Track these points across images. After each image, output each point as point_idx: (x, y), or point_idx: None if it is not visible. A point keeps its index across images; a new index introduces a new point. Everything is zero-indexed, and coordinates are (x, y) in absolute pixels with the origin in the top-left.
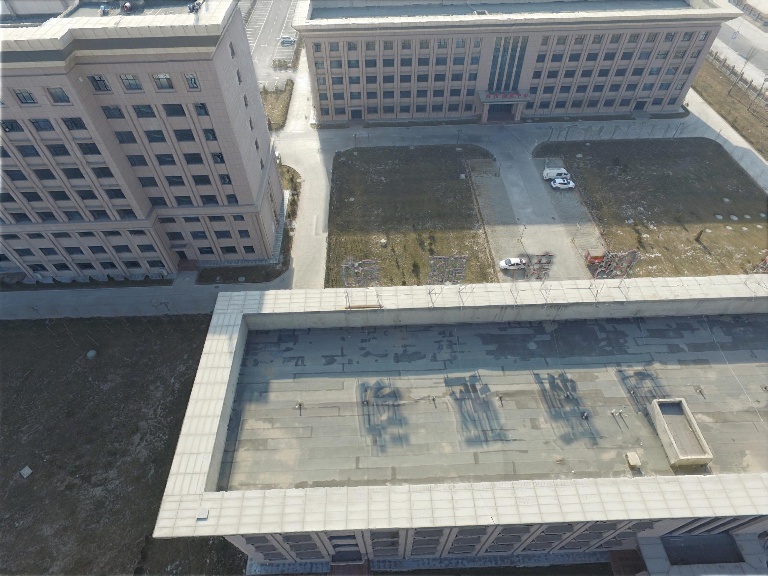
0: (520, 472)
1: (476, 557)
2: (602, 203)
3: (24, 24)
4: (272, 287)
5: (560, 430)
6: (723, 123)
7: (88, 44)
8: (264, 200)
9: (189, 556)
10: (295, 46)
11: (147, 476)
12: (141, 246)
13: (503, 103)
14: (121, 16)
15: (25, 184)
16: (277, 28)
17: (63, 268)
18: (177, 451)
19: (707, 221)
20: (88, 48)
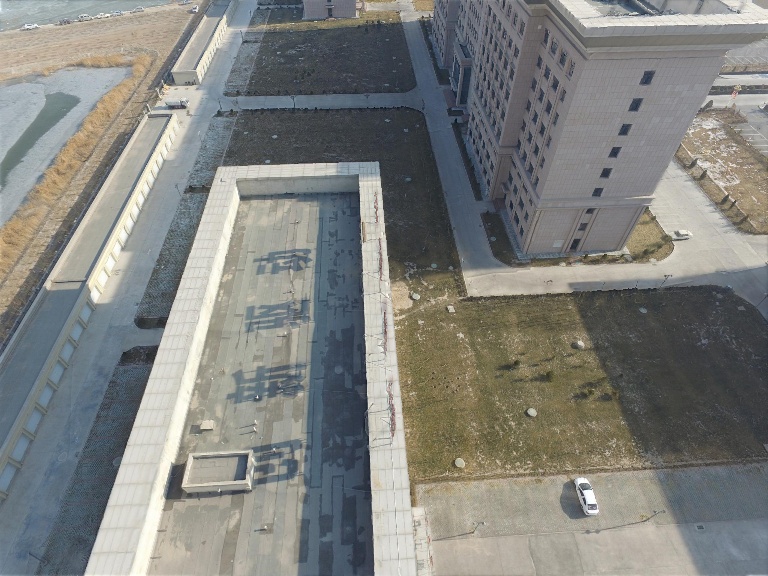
0: (222, 342)
1: None
2: None
3: None
4: (489, 260)
5: (249, 376)
6: None
7: None
8: (566, 214)
9: None
10: None
11: None
12: None
13: None
14: None
15: None
16: None
17: None
18: (262, 166)
19: None
20: (549, 6)
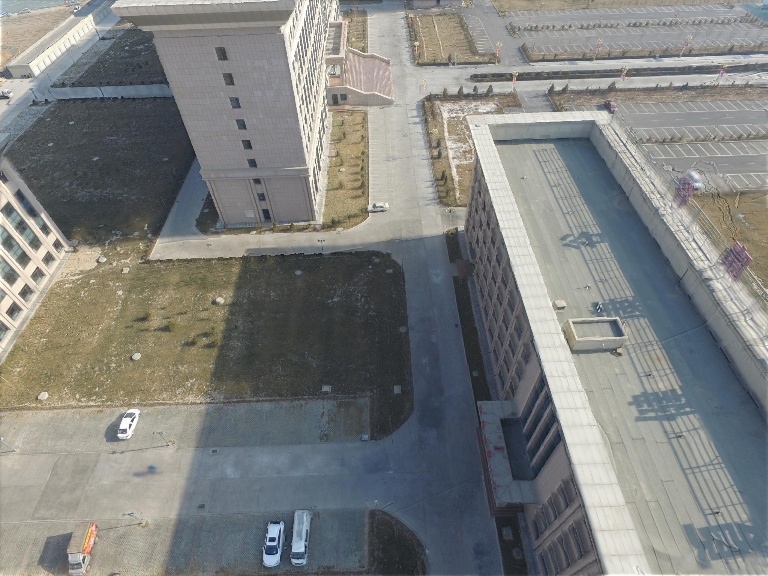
0: None
1: None
2: None
3: None
4: (189, 229)
5: None
6: None
7: None
8: (237, 185)
9: None
10: None
11: (63, 199)
12: None
13: None
14: None
15: None
16: (734, 168)
17: None
18: None
19: None
20: None
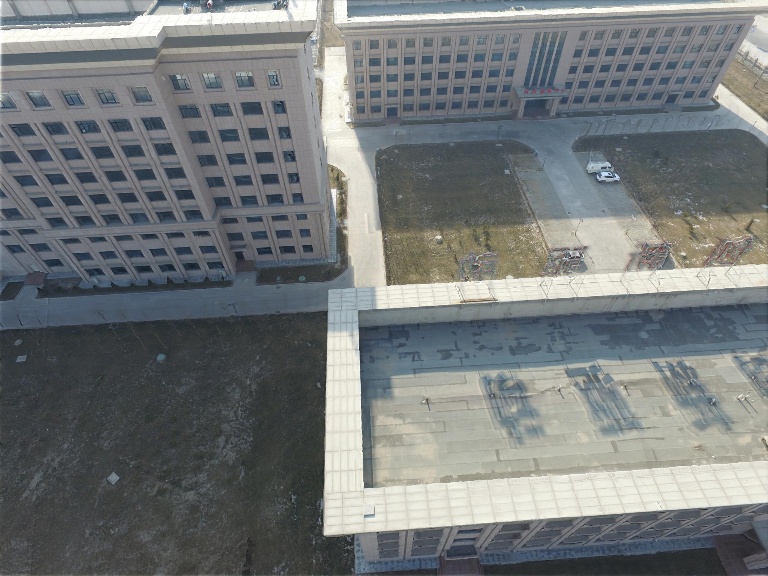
0: (661, 459)
1: (583, 547)
2: (648, 195)
3: (99, 23)
4: (334, 286)
5: (691, 416)
6: (754, 115)
7: (178, 42)
8: None
9: (294, 557)
10: (318, 45)
11: (238, 478)
12: (203, 247)
13: (540, 98)
14: (211, 13)
15: (94, 186)
16: None
17: (120, 272)
18: (327, 449)
19: (754, 211)
20: (176, 46)
